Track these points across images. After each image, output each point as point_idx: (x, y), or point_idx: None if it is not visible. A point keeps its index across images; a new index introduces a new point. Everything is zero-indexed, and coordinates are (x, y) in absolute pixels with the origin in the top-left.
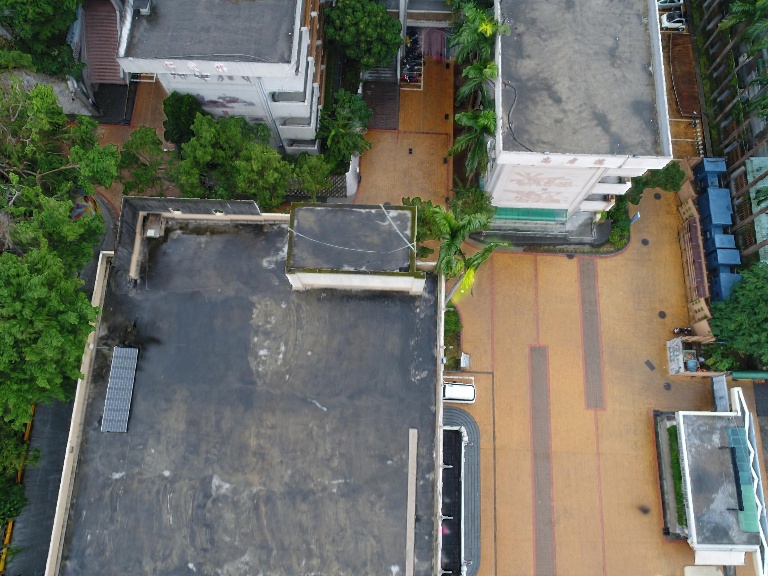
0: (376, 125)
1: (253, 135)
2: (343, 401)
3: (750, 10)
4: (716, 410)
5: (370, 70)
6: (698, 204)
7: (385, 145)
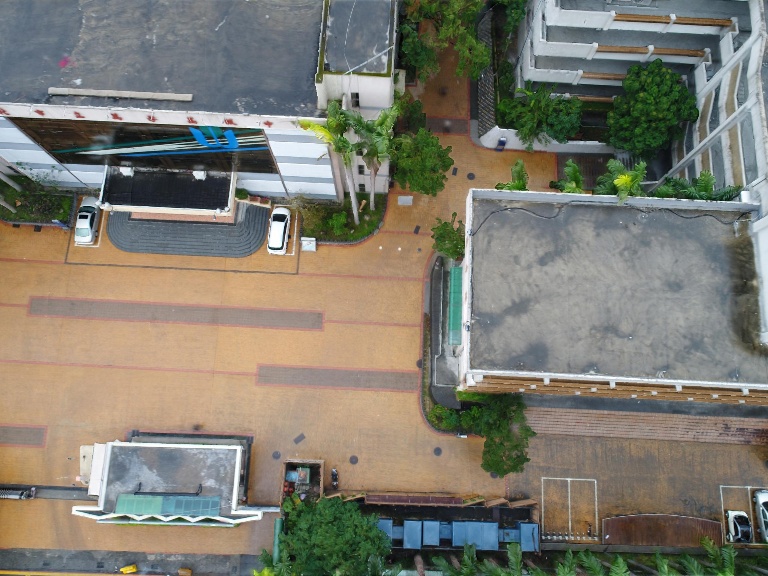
0: (562, 166)
1: (507, 0)
2: (223, 43)
3: (725, 568)
4: (249, 506)
5: (627, 159)
6: (485, 521)
7: (539, 175)
